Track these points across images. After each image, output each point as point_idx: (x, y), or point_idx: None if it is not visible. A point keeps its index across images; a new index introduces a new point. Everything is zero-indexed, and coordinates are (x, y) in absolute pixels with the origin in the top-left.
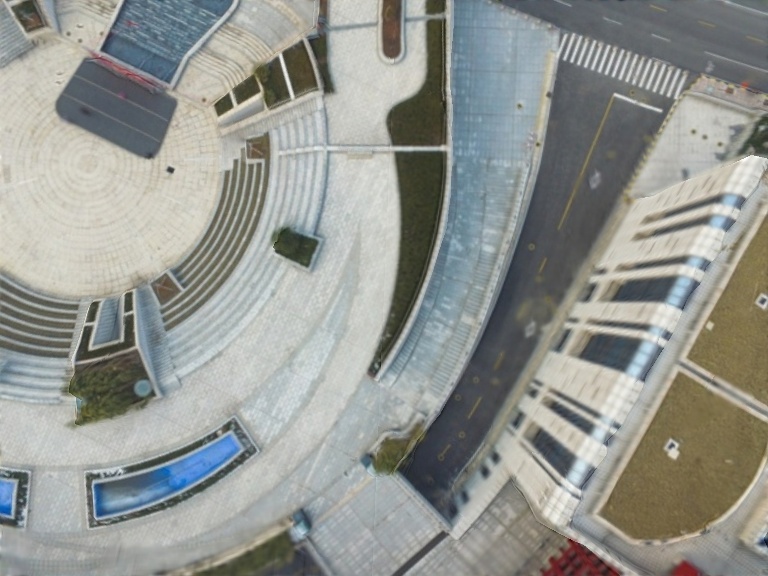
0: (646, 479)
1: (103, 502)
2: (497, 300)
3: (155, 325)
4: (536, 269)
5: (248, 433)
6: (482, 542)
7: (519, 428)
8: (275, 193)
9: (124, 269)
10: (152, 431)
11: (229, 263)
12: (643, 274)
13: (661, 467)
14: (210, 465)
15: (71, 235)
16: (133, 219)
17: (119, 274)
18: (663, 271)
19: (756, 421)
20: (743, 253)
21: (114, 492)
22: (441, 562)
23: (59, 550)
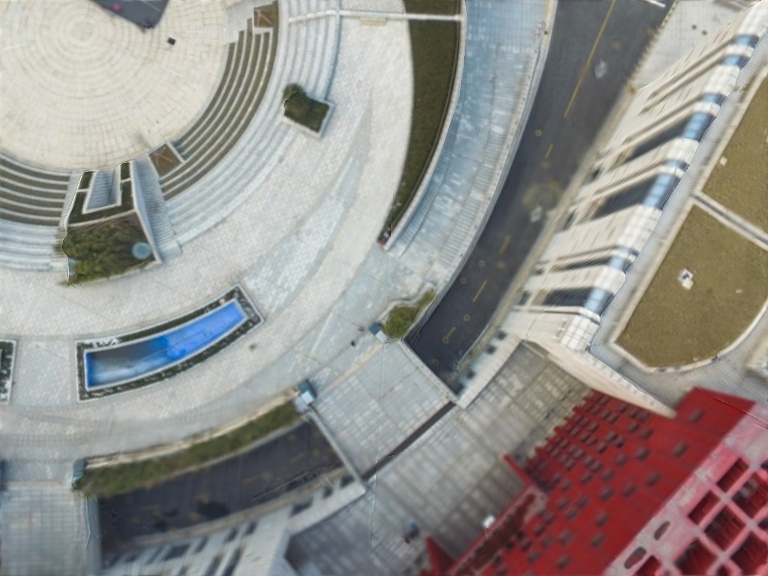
0: (661, 308)
1: (95, 373)
2: (504, 184)
3: (154, 194)
4: (542, 155)
5: (252, 302)
6: (488, 413)
7: (526, 301)
8: (283, 62)
9: (119, 142)
10: (150, 299)
11: (233, 133)
12: (655, 130)
13: (676, 297)
14: (211, 335)
15: (62, 105)
16: (130, 90)
17: (114, 147)
18: (678, 116)
19: (765, 254)
20: (755, 92)
21: (107, 363)
22: (447, 433)
23: (46, 424)
